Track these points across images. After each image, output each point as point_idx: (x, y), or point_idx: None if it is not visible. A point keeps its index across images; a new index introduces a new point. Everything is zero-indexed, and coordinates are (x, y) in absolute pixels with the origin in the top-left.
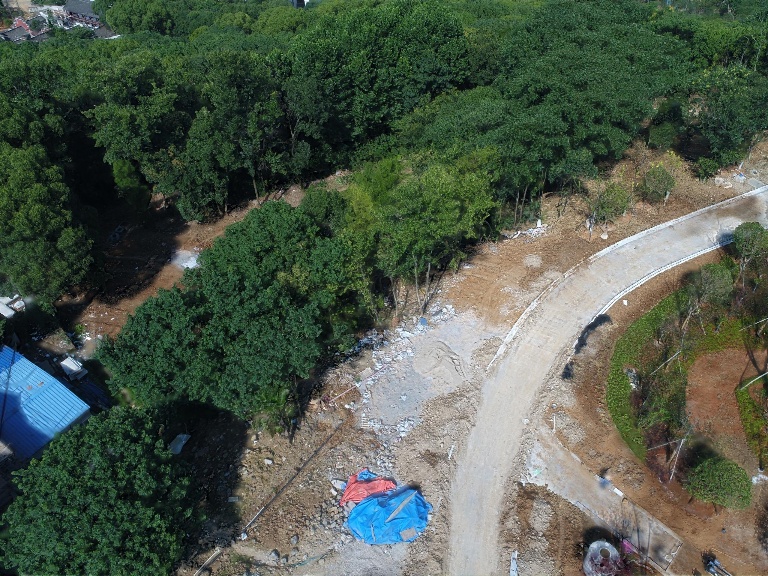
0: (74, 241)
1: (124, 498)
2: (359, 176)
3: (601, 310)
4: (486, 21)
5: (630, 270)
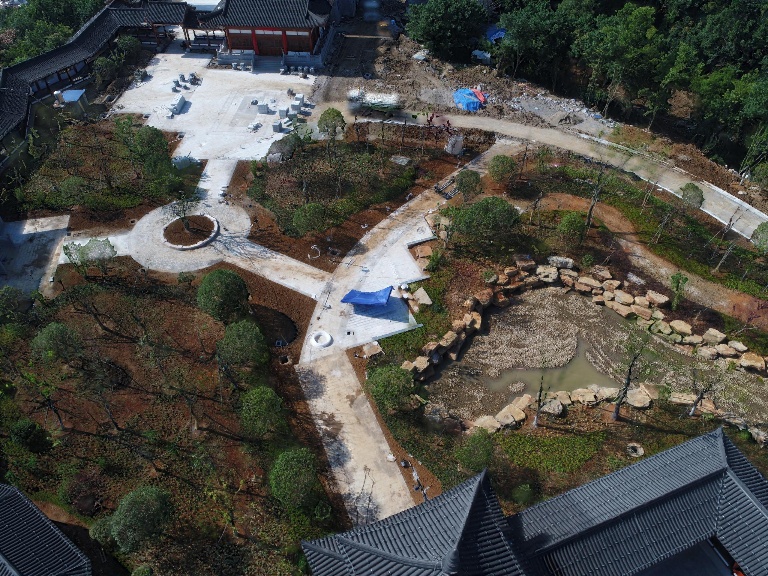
0: (587, 4)
1: (446, 8)
2: None
3: (645, 179)
4: None
5: (704, 201)
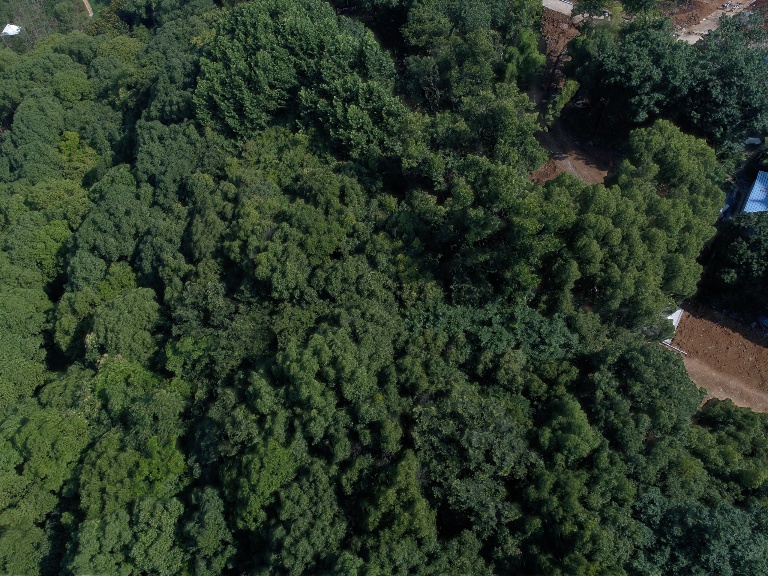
0: None
1: None
2: (511, 65)
3: None
4: (163, 37)
5: (559, 4)
